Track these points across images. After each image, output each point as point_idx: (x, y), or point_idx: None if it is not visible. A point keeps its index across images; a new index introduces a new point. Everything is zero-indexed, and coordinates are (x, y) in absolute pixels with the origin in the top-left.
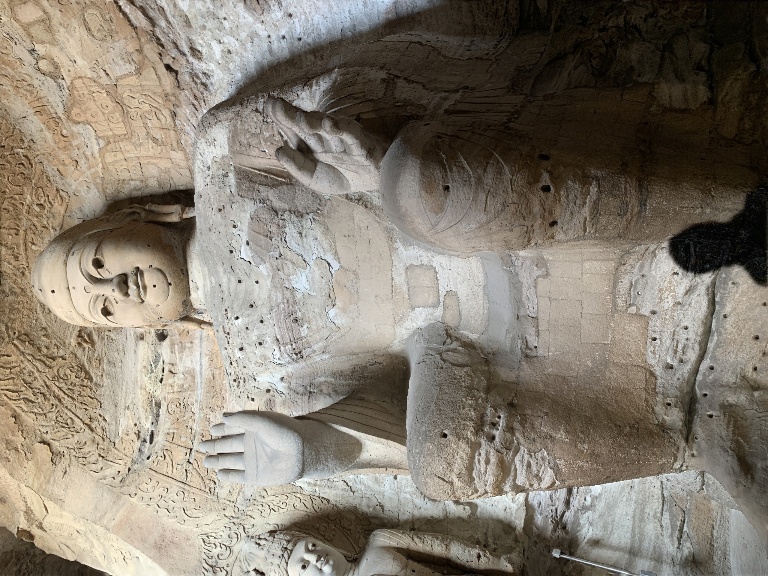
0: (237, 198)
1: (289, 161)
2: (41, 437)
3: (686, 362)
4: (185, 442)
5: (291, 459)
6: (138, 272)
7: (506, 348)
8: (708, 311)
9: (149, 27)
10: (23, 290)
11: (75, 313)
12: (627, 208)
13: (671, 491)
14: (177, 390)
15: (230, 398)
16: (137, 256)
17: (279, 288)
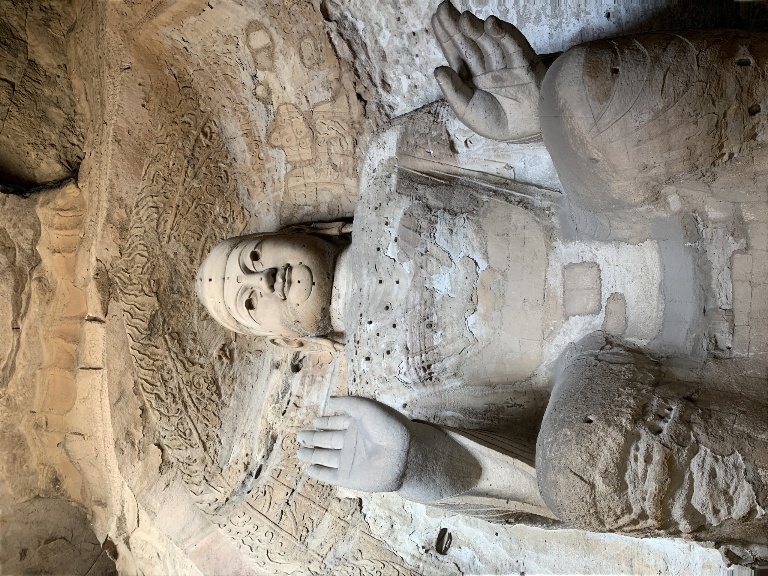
0: (395, 195)
1: (446, 77)
2: (158, 440)
3: None
4: (289, 481)
5: (392, 456)
6: (288, 267)
7: (686, 351)
8: None
9: (351, 58)
10: (188, 292)
11: (223, 305)
12: None
13: None
14: (296, 425)
15: None
16: (291, 252)
17: (419, 288)
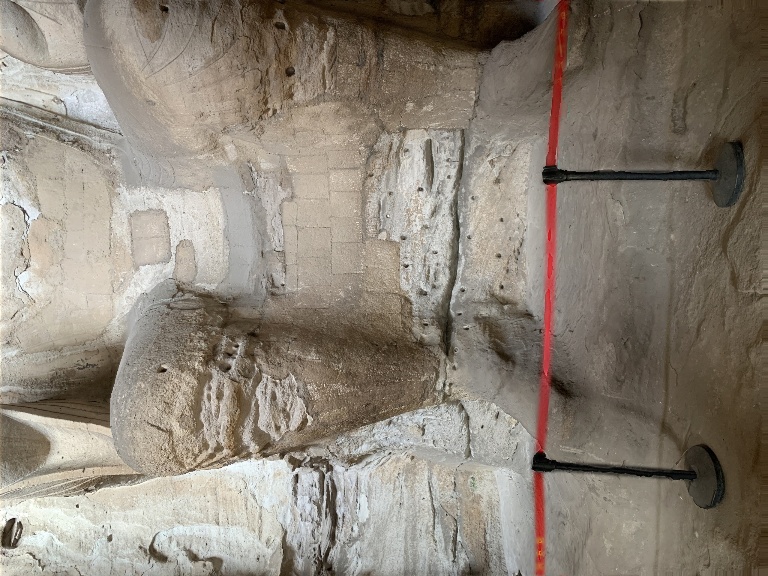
0: None
1: None
2: None
3: (439, 287)
4: None
5: None
6: None
7: (249, 291)
8: (454, 233)
9: None
10: None
11: None
12: (365, 58)
13: (441, 500)
14: None
15: None
16: None
17: None
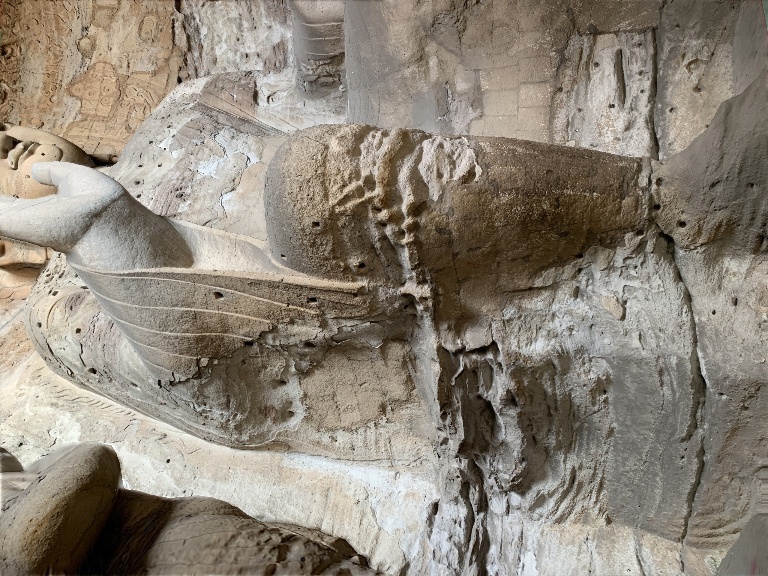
0: (187, 111)
1: None
2: None
3: None
4: None
5: (93, 197)
6: None
7: None
8: (652, 143)
9: (185, 48)
10: None
11: None
12: None
13: None
14: None
15: (3, 369)
16: (48, 135)
17: (181, 169)
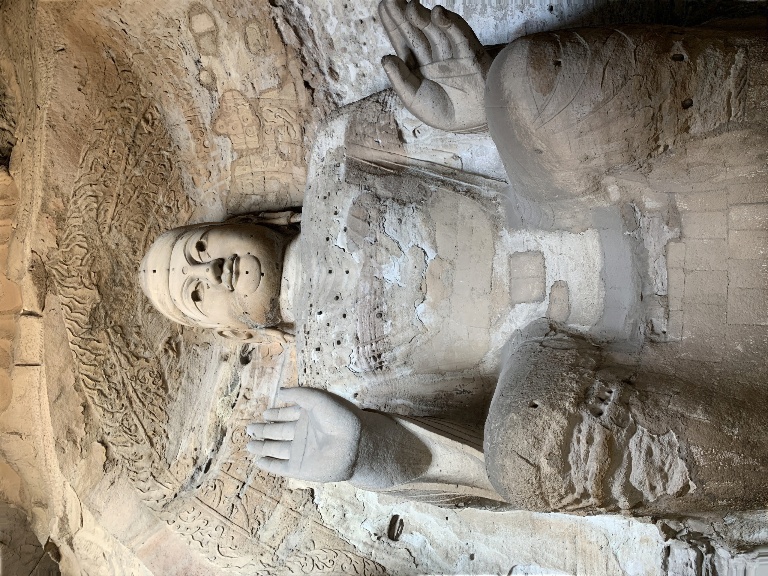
0: (343, 184)
1: (394, 66)
2: (102, 437)
3: None
4: (240, 475)
5: (344, 445)
6: (235, 258)
7: (625, 336)
8: None
9: (297, 45)
10: (131, 284)
11: (168, 297)
12: None
13: None
14: (246, 417)
15: None
16: (238, 242)
17: (369, 278)
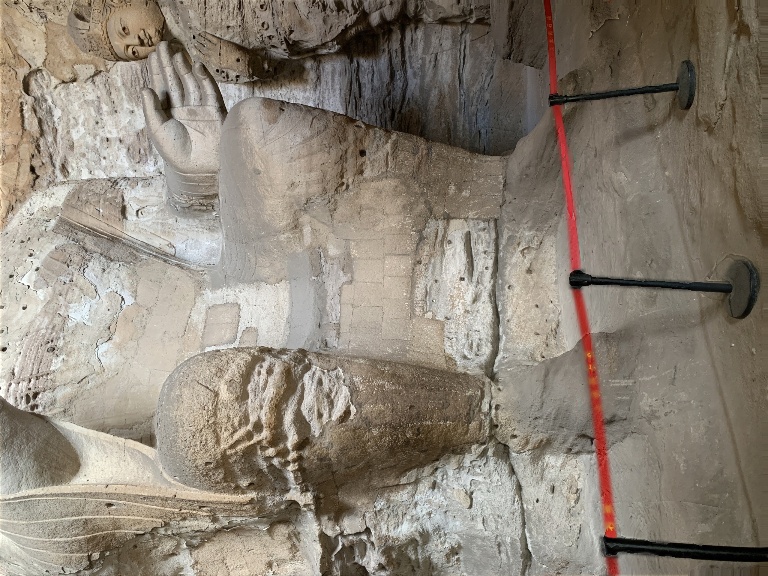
0: (49, 233)
1: (151, 94)
2: None
3: (482, 355)
4: None
5: None
6: None
7: None
8: (494, 318)
9: (37, 134)
10: None
11: None
12: (418, 150)
13: None
14: None
15: None
16: None
17: (50, 314)
